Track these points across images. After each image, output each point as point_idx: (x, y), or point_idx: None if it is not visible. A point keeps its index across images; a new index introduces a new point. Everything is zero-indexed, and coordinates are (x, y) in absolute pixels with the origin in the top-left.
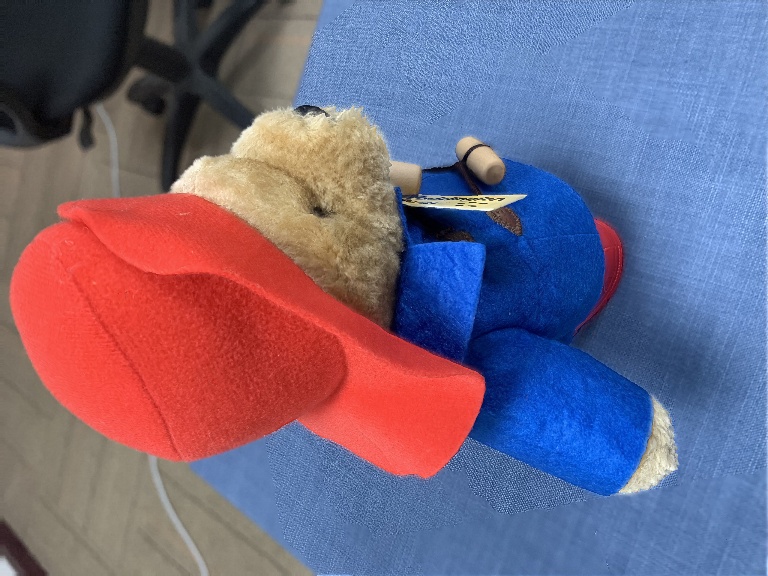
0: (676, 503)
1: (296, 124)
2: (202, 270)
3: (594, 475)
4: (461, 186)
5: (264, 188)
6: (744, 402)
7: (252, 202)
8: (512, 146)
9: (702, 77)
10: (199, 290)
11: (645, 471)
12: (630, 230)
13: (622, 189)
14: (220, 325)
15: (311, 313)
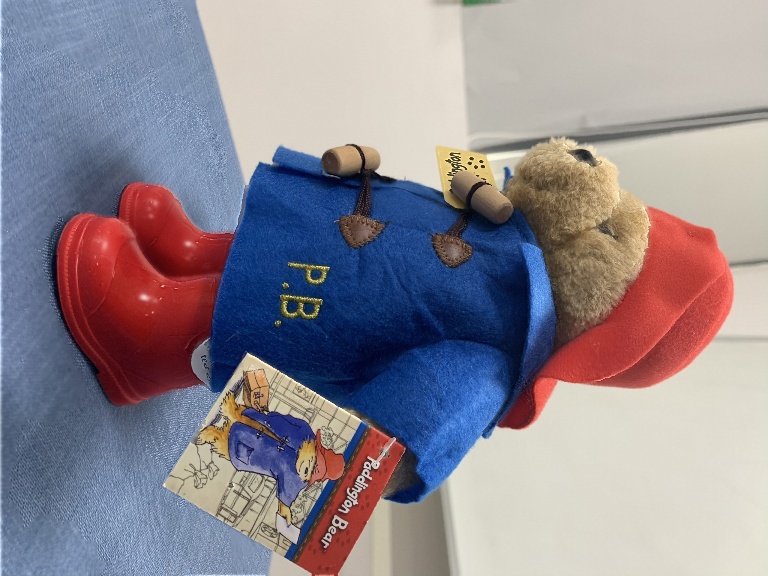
0: None
1: None
2: None
3: None
4: None
5: None
6: None
7: None
8: (31, 172)
9: None
10: None
11: None
12: (138, 173)
13: (115, 141)
14: None
15: None
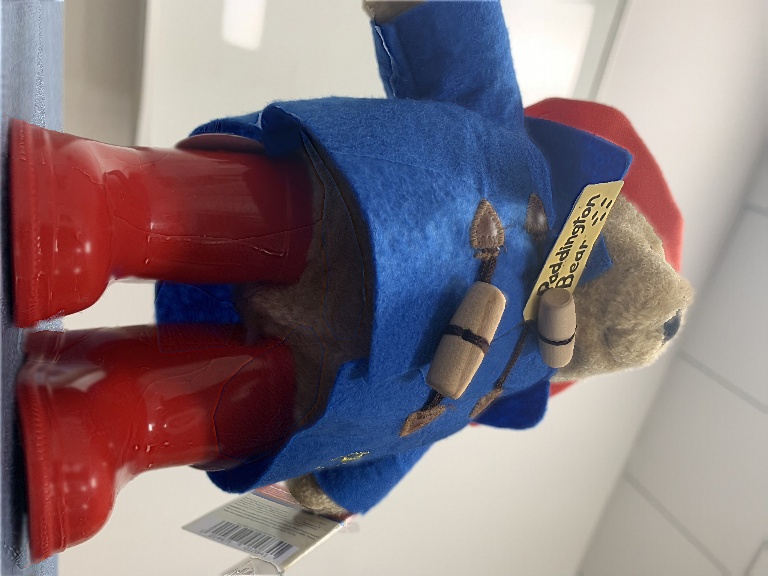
0: None
1: None
2: None
3: None
4: None
5: None
6: None
7: None
8: None
9: None
10: None
11: None
12: None
13: None
14: None
15: None
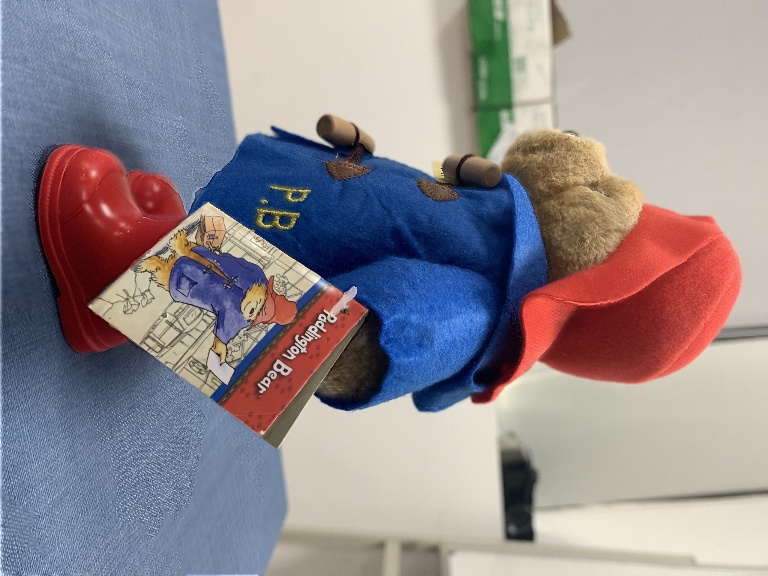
0: None
1: None
2: None
3: None
4: None
5: None
6: None
7: None
8: (44, 90)
9: None
10: None
11: None
12: None
13: (132, 135)
14: None
15: None
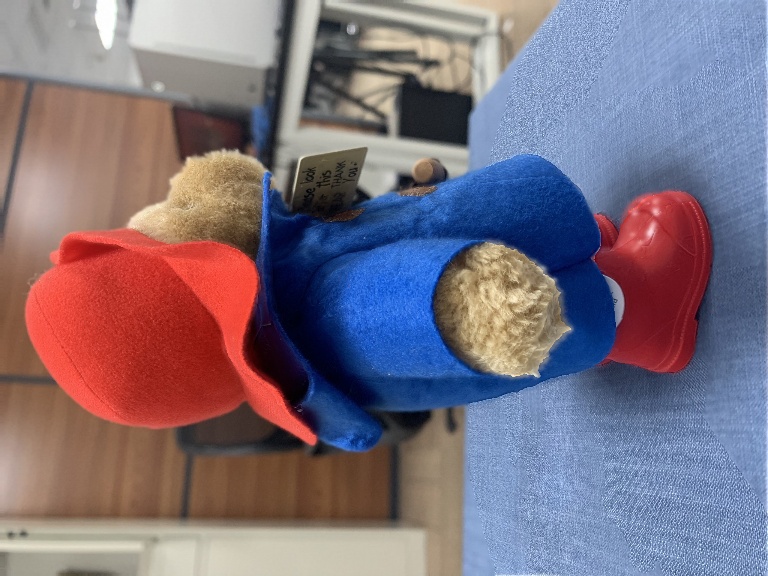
0: None
1: None
2: (62, 240)
3: (411, 331)
4: None
5: None
6: None
7: None
8: (590, 186)
9: (696, 4)
10: (85, 266)
11: (470, 309)
12: (699, 180)
13: (677, 149)
14: (91, 281)
15: None
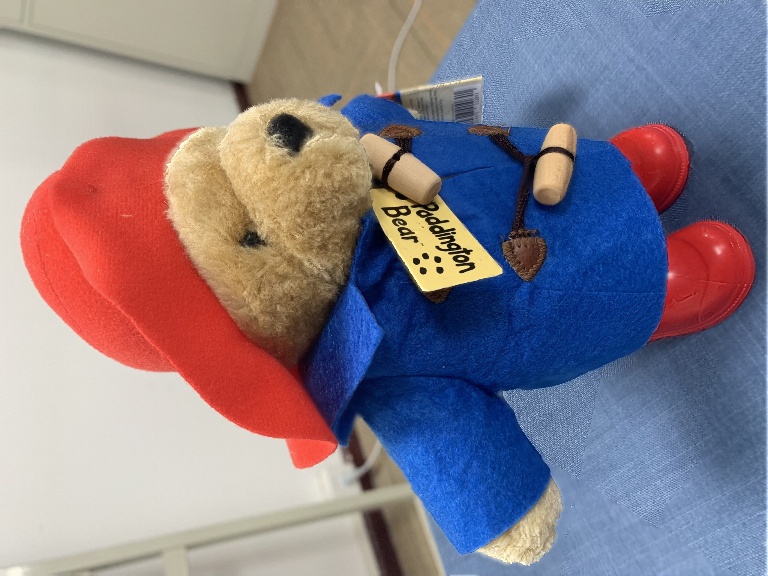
0: (645, 538)
1: (253, 149)
2: (98, 291)
3: None
4: (512, 190)
5: (201, 208)
6: (761, 512)
7: (186, 219)
8: (713, 95)
9: None
10: None
11: (492, 552)
12: None
13: None
14: None
15: (168, 355)
